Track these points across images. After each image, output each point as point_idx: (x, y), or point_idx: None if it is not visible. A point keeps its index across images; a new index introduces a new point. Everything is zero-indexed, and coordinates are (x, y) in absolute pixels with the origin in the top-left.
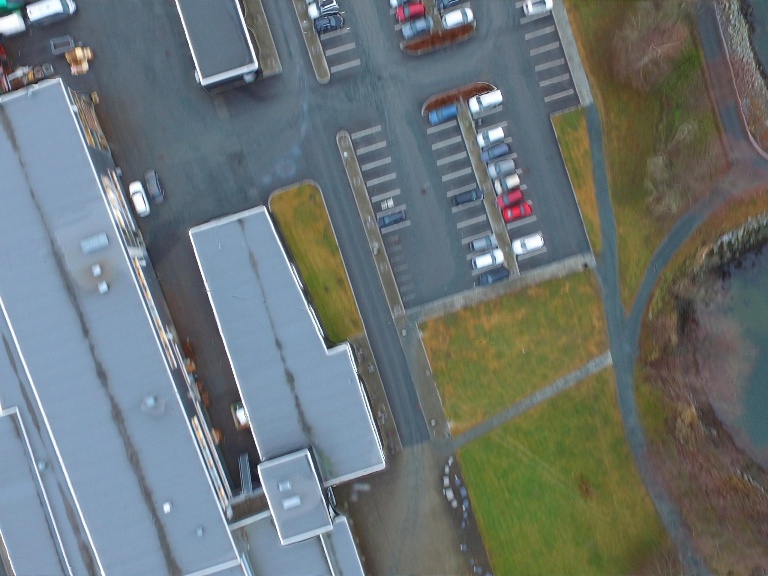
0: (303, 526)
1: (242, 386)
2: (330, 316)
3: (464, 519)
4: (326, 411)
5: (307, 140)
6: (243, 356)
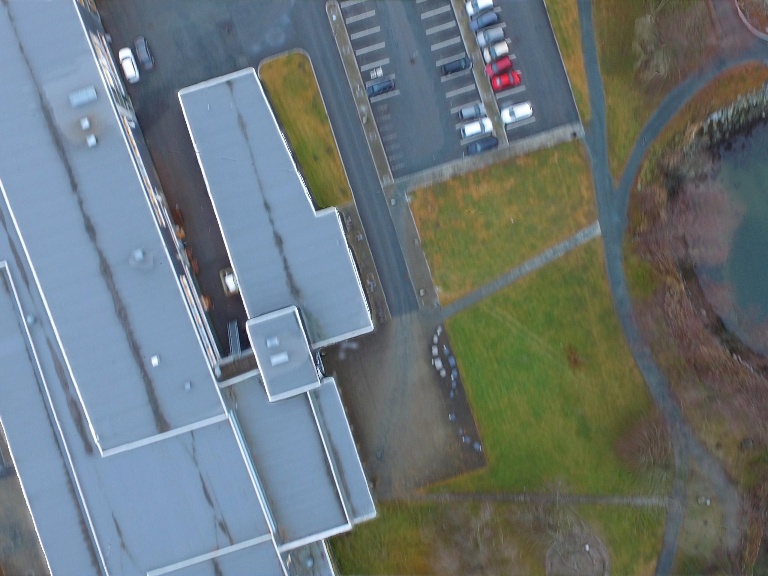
0: (291, 383)
1: (231, 248)
2: (319, 185)
3: (453, 388)
4: (314, 273)
5: (296, 8)
6: (232, 218)
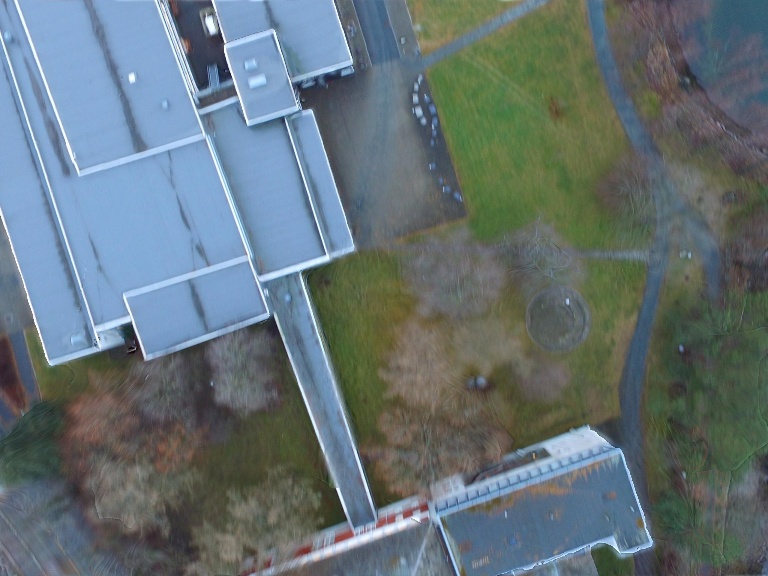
0: (269, 107)
1: None
2: None
3: (433, 137)
4: (294, 7)
5: None
6: None
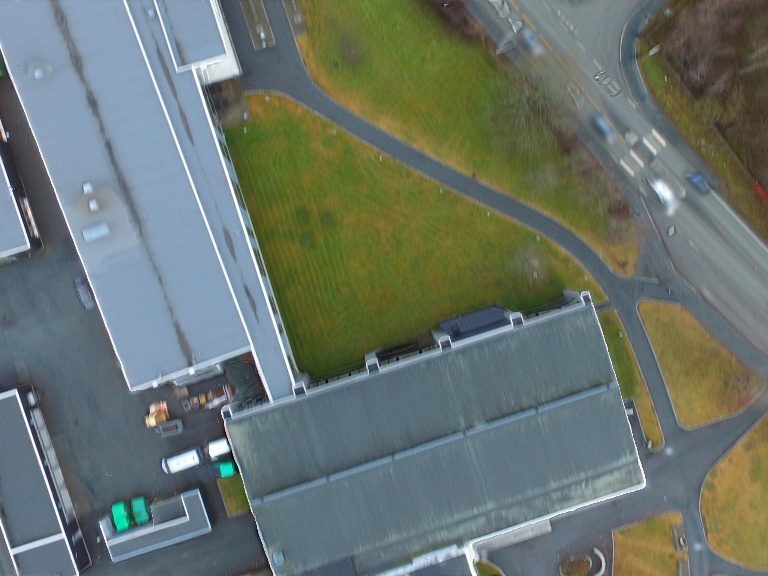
0: None
1: None
2: None
3: None
4: None
5: None
6: None
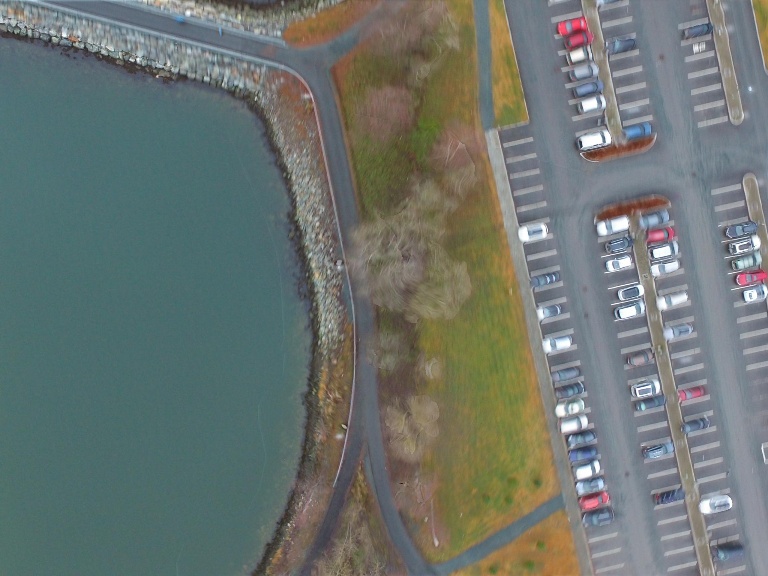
0: None
1: None
2: None
3: None
4: None
5: None
6: None
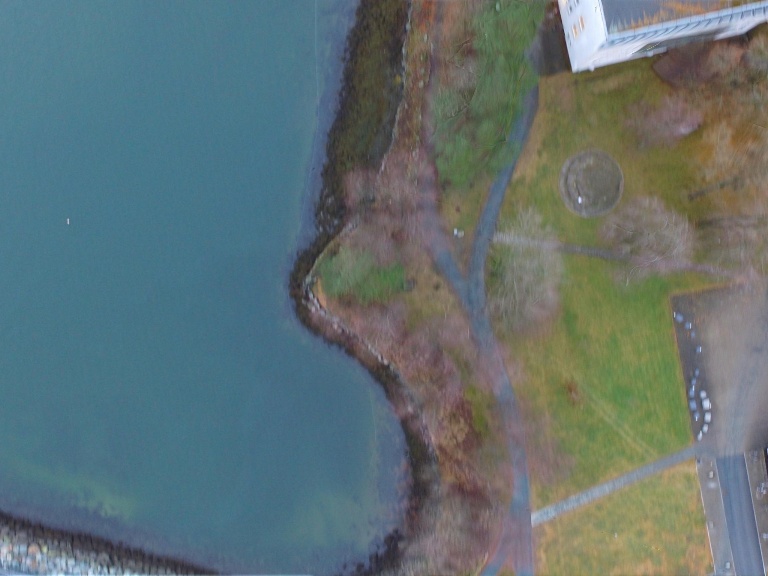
0: None
1: None
2: None
3: (696, 378)
4: None
5: None
6: None
